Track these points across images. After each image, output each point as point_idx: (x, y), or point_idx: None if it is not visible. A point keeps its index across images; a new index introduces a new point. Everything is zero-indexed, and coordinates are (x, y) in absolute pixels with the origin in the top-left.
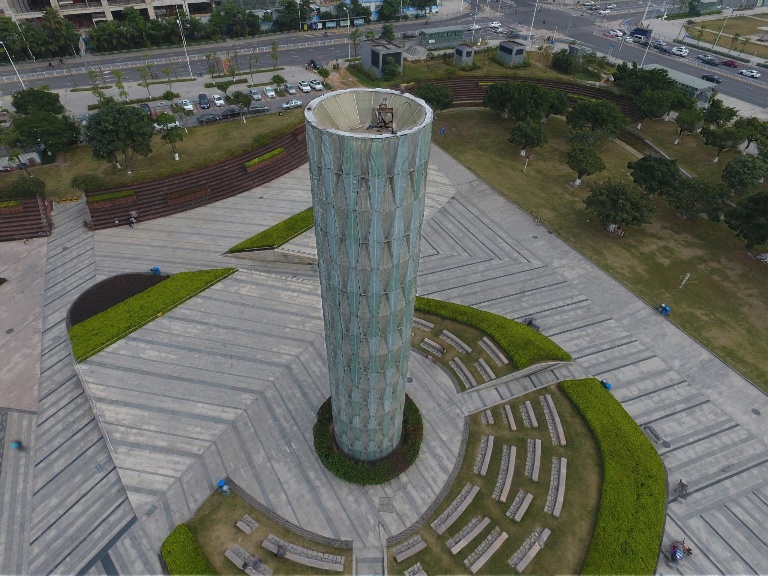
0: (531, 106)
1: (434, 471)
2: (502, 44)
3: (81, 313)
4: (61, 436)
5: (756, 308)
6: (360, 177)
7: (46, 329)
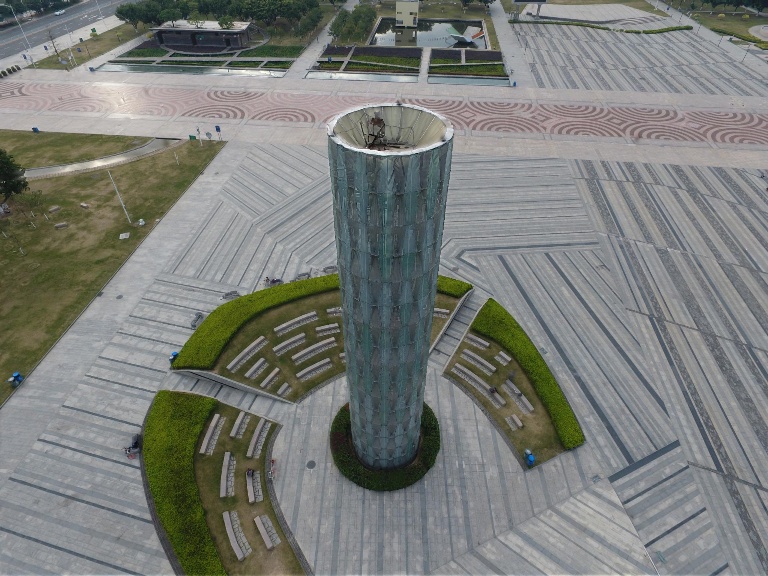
0: None
1: None
2: None
3: None
4: None
5: None
6: None
7: None
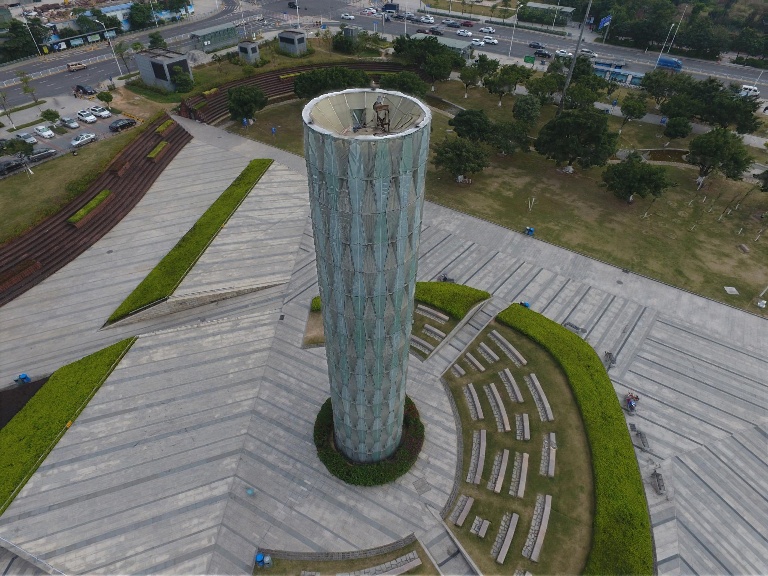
0: None
1: (443, 436)
2: (281, 35)
3: None
4: None
5: (582, 208)
6: (392, 177)
7: None
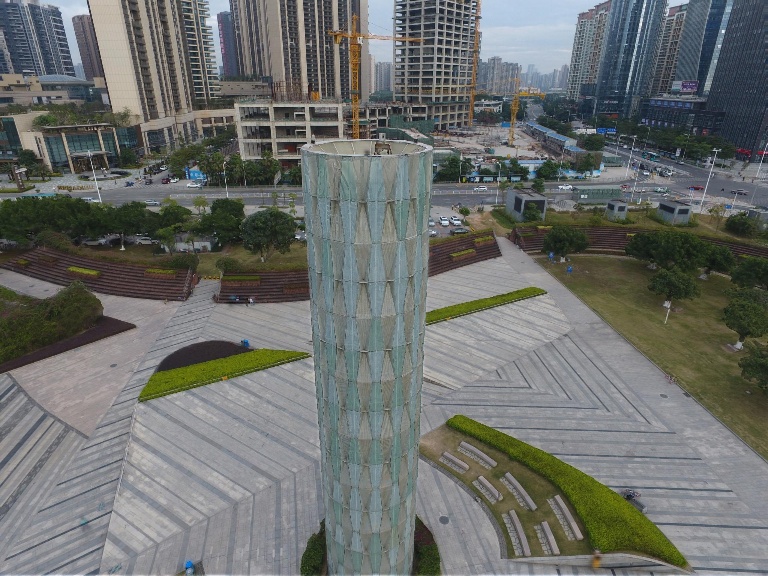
0: (682, 256)
1: None
2: (663, 203)
3: (169, 363)
4: (92, 465)
5: None
6: (332, 200)
7: (138, 370)
